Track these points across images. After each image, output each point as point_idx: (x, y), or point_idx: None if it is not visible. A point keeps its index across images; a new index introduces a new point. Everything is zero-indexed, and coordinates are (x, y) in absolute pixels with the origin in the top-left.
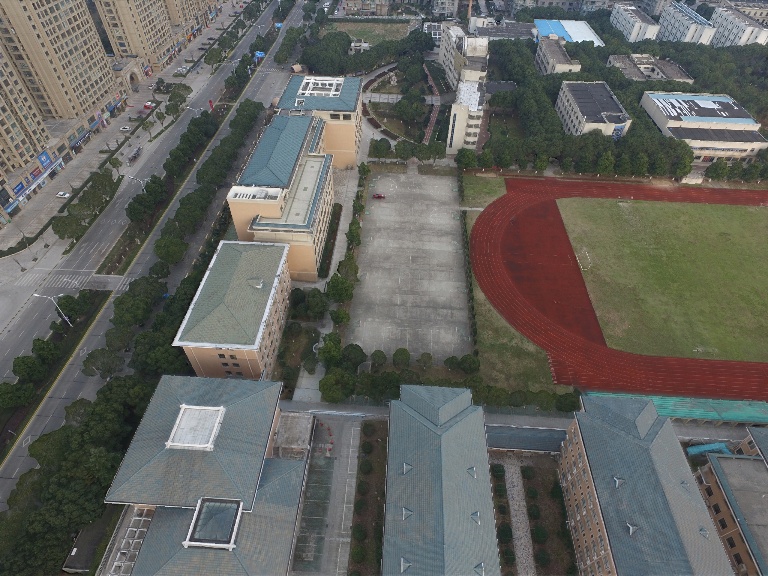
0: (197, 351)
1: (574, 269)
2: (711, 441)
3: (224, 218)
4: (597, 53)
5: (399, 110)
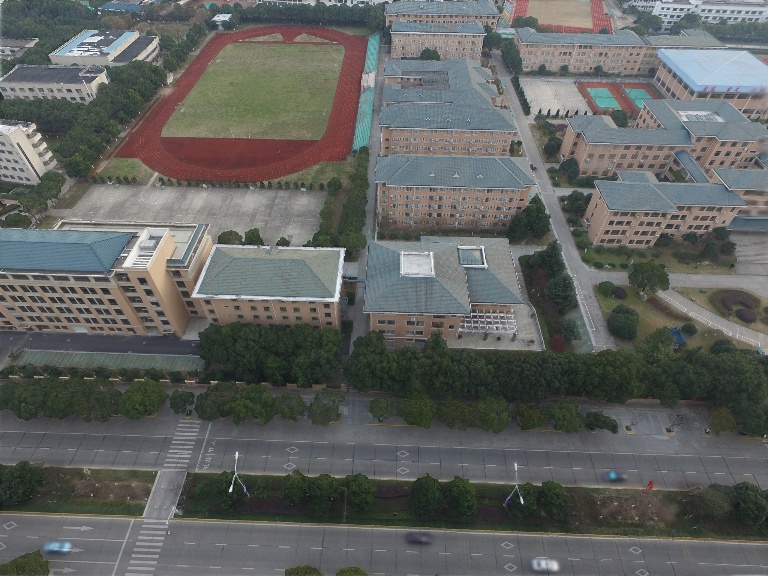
0: None
1: (248, 141)
2: None
3: (74, 374)
4: None
5: None
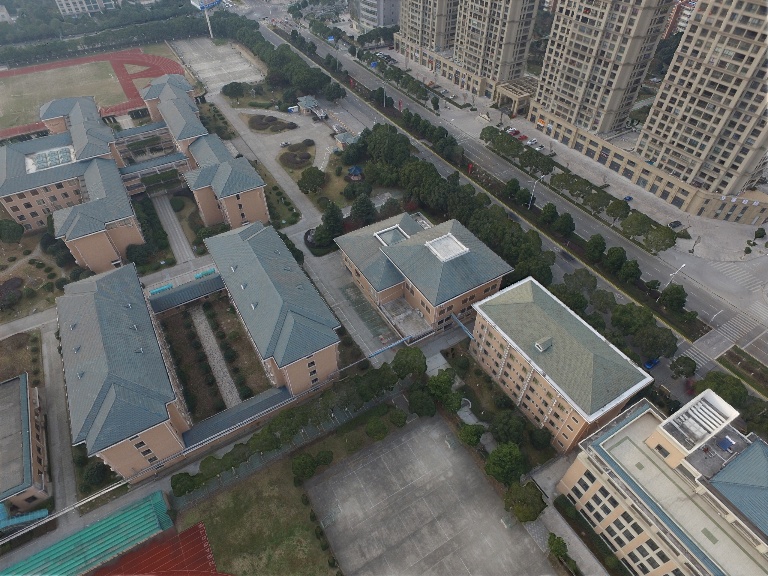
0: None
1: None
2: (14, 532)
3: None
4: None
5: None
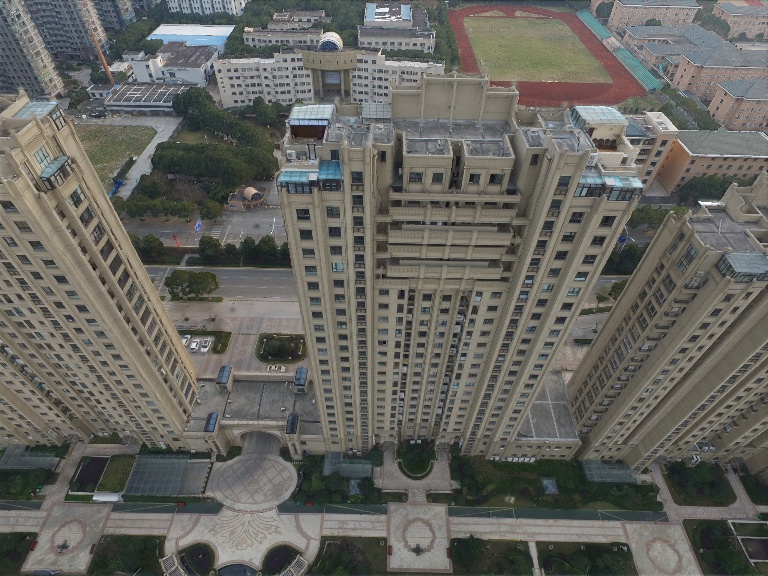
0: None
1: (559, 83)
2: None
3: None
4: None
5: None
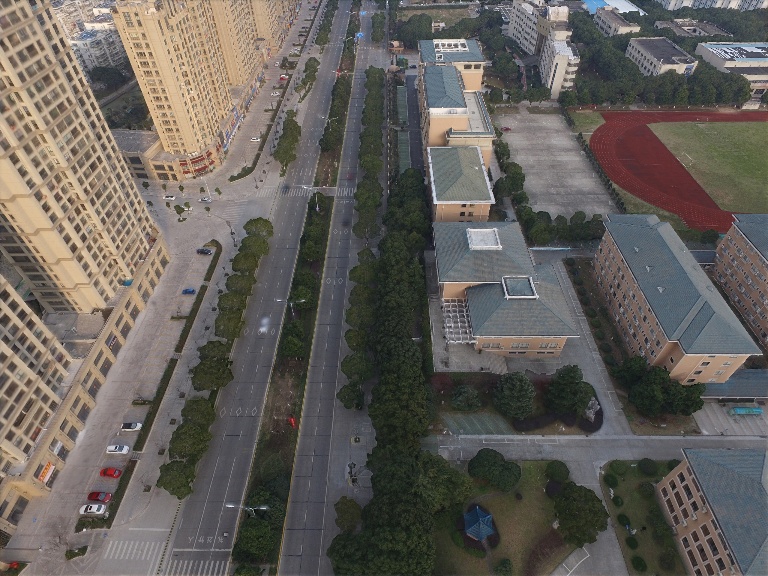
0: (446, 210)
1: (679, 166)
2: None
3: None
4: (644, 20)
5: (499, 68)
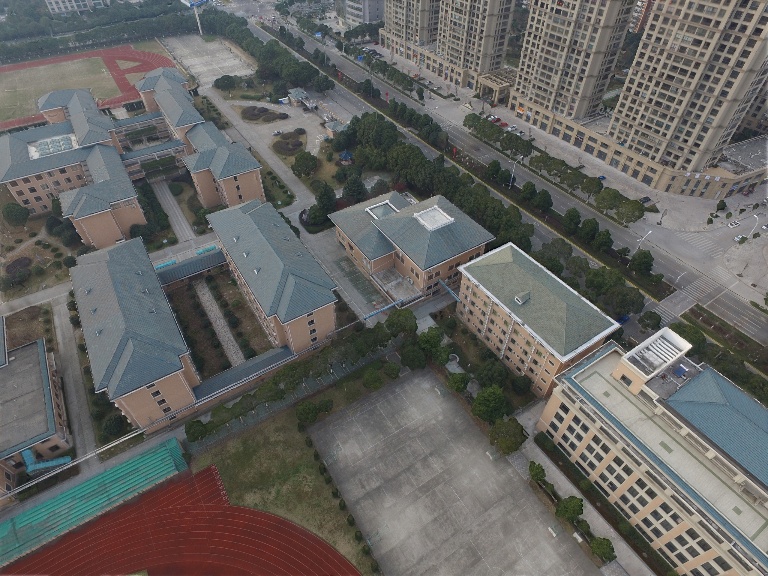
0: None
1: None
2: (41, 475)
3: None
4: None
5: None
